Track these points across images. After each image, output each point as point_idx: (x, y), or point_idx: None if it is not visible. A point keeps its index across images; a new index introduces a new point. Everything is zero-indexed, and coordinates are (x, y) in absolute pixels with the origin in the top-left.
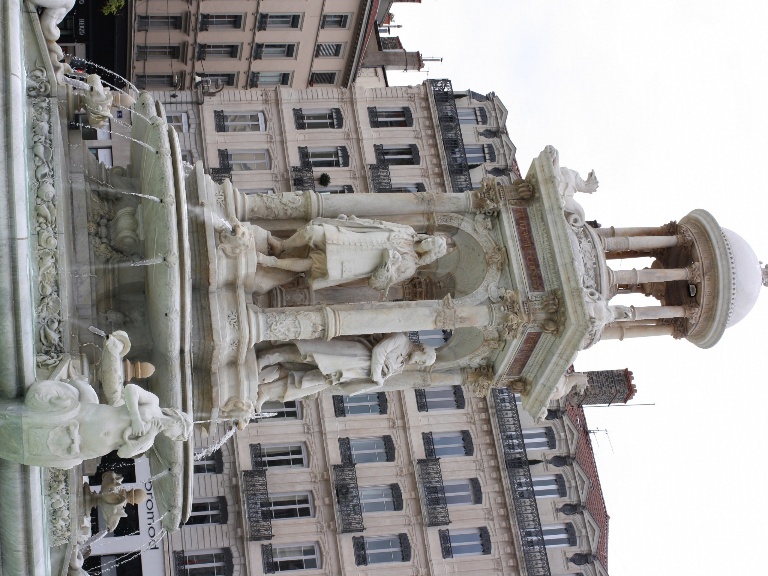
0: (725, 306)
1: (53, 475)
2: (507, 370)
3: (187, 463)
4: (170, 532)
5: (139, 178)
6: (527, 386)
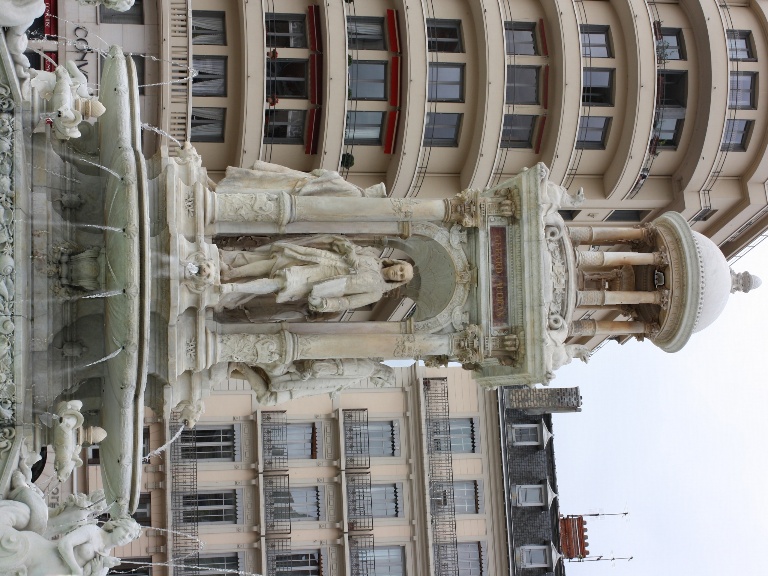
0: None
1: None
2: None
3: None
4: None
5: (106, 390)
6: None
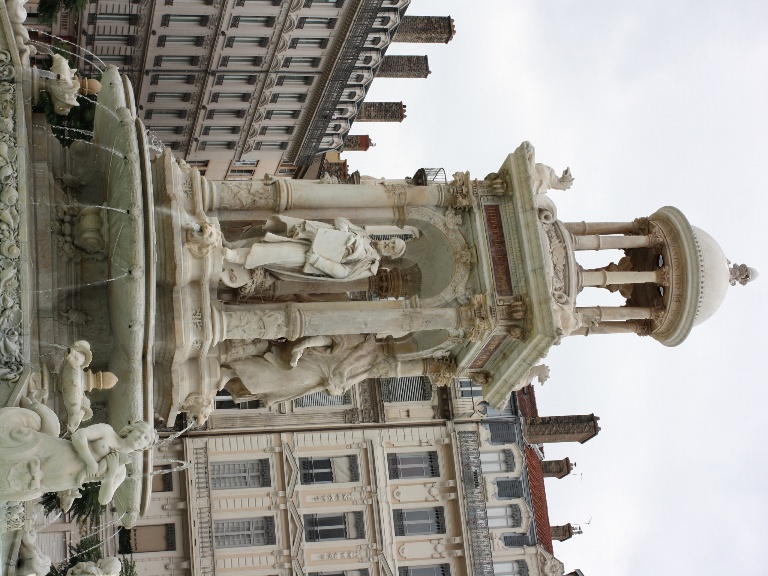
0: (678, 216)
1: (1, 108)
2: (494, 282)
3: (140, 133)
4: (131, 210)
5: None
6: (525, 300)
